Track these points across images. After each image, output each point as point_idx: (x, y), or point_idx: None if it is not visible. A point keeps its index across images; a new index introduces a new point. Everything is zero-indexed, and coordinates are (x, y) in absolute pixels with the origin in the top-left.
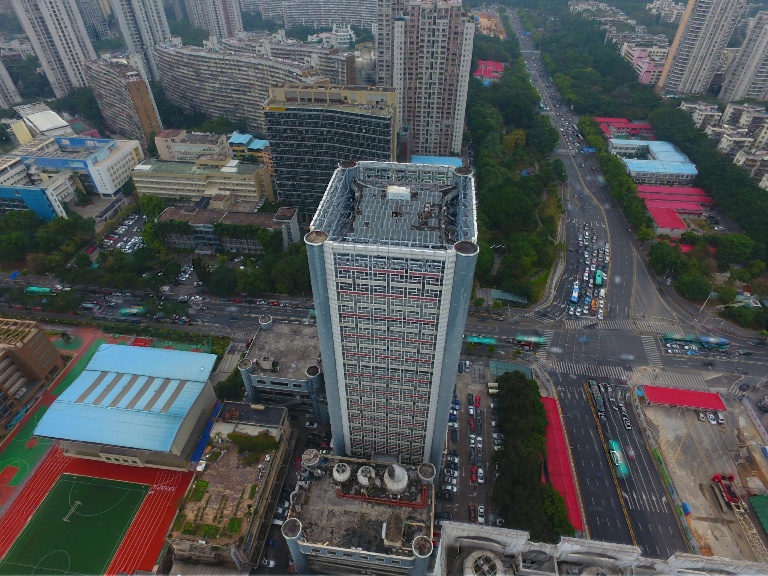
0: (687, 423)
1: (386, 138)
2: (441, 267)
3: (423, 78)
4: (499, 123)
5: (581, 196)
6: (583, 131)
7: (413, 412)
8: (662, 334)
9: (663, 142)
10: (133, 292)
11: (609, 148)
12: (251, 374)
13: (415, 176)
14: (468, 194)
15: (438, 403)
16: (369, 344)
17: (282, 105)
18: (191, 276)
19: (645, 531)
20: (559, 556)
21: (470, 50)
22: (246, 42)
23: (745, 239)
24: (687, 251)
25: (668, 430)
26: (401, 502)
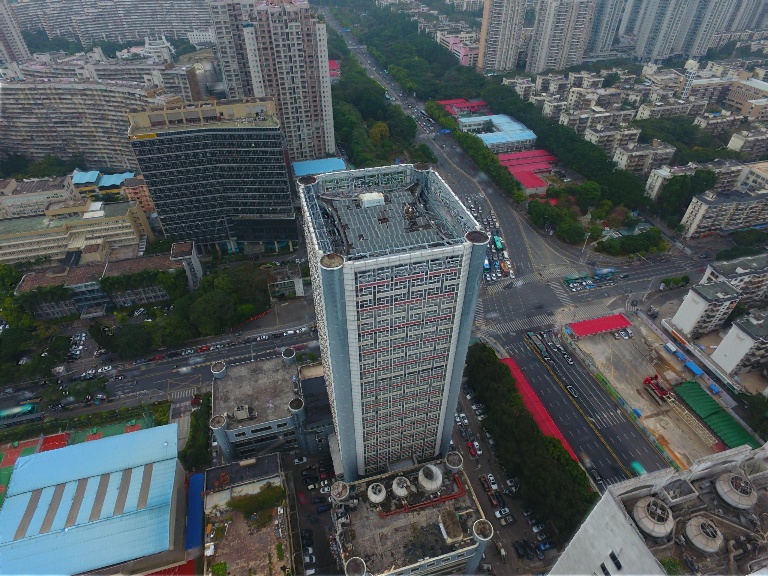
0: (609, 344)
1: (279, 149)
2: (459, 261)
3: (285, 83)
4: (358, 118)
5: (454, 174)
6: (433, 115)
7: (427, 409)
8: (563, 277)
9: (501, 115)
10: (15, 386)
11: (460, 127)
12: (228, 430)
13: (375, 180)
14: (442, 187)
15: (450, 392)
16: (387, 356)
17: (149, 131)
18: (85, 346)
19: (617, 443)
20: (690, 478)
21: (326, 50)
22: (54, 66)
23: (594, 185)
24: (555, 204)
25: (599, 355)
26: (442, 498)
